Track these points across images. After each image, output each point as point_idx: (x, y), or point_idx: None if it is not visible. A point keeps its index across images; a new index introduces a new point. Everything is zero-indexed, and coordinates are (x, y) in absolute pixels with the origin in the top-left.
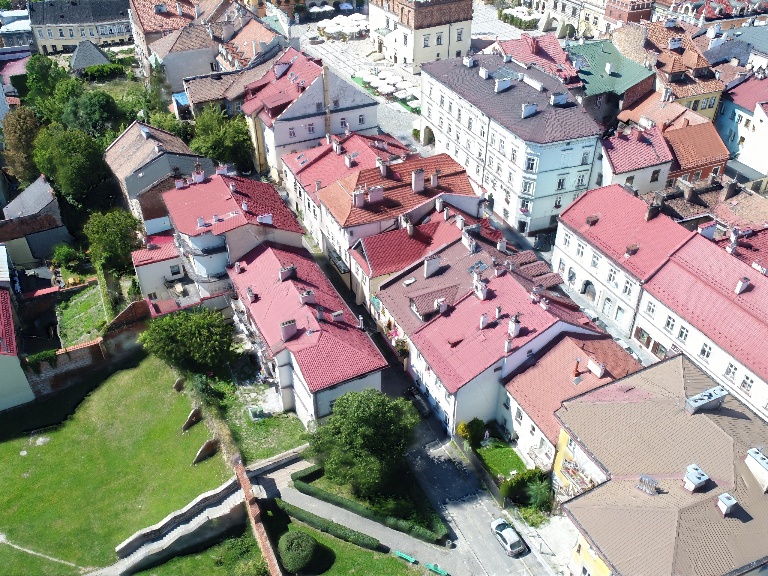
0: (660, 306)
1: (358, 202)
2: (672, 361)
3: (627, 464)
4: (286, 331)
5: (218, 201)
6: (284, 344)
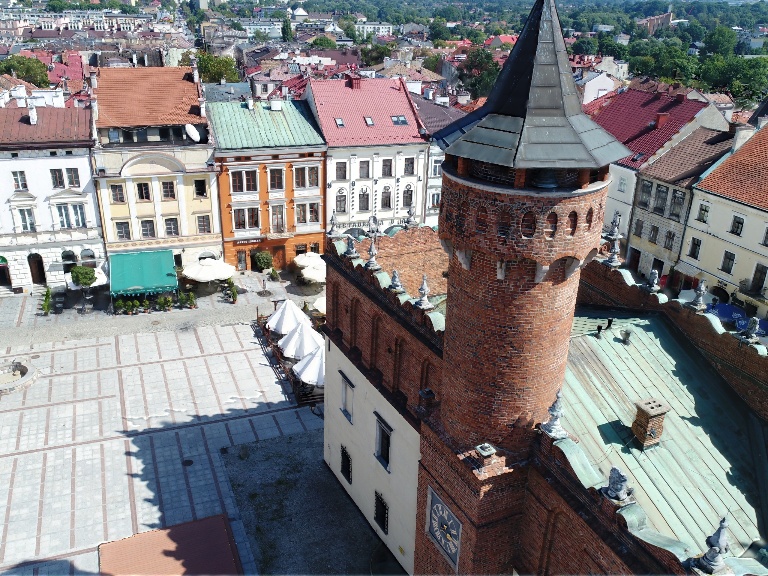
0: None
1: None
2: None
3: None
4: None
5: None
6: None
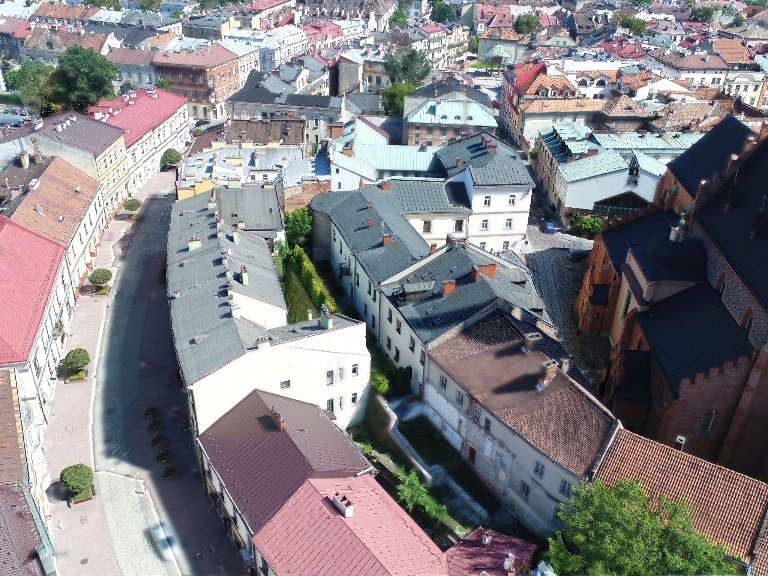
0: None
1: None
2: None
3: None
4: None
5: None
6: None
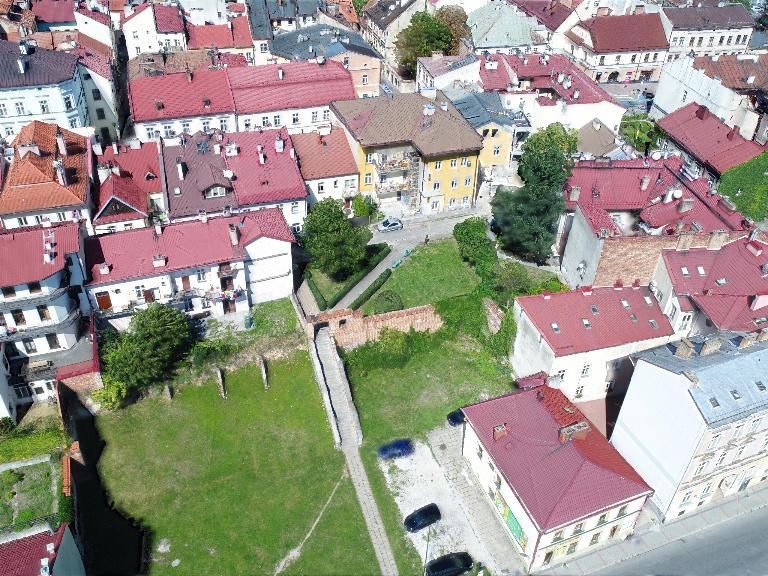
0: (255, 117)
1: (65, 180)
2: (337, 105)
3: (406, 132)
4: (236, 234)
5: (8, 247)
6: (240, 246)
